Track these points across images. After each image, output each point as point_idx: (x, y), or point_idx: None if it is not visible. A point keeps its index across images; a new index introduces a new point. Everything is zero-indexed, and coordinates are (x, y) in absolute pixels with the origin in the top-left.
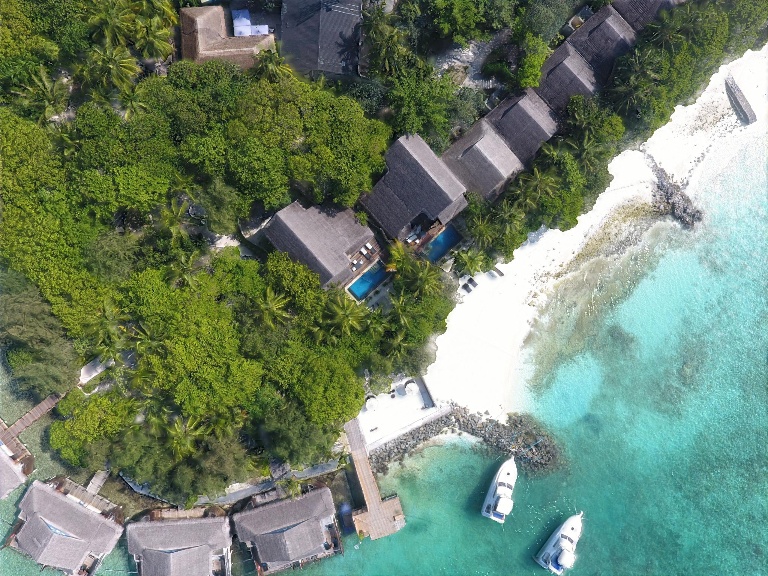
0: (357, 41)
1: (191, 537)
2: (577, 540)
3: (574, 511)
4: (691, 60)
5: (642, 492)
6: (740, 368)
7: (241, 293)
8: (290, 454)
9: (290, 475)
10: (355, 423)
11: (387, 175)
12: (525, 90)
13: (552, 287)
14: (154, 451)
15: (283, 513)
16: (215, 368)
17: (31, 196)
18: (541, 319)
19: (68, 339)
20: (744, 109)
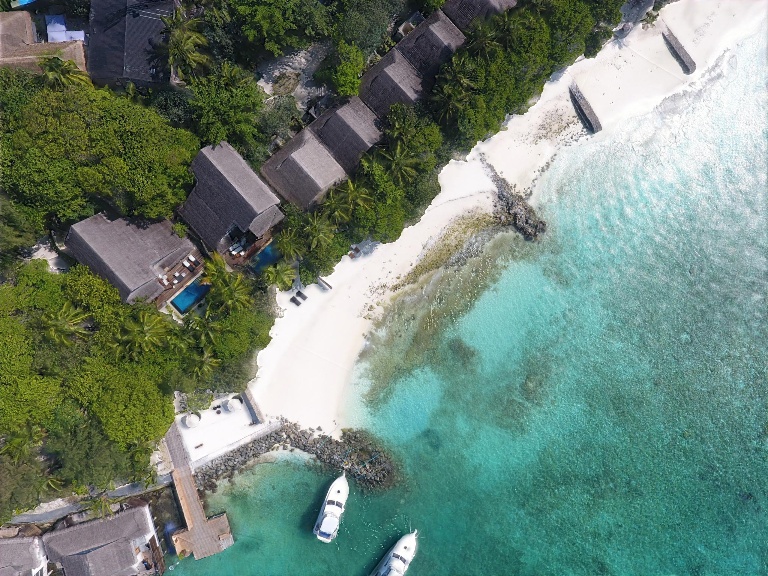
0: (169, 48)
1: None
2: (410, 559)
3: (408, 529)
4: (508, 68)
5: (483, 509)
6: (586, 382)
7: (38, 308)
8: (76, 475)
9: (109, 493)
10: (178, 440)
11: (197, 186)
12: (349, 98)
13: (389, 300)
14: None
15: (93, 533)
16: (5, 386)
17: None
18: (378, 332)
19: None
20: (588, 117)
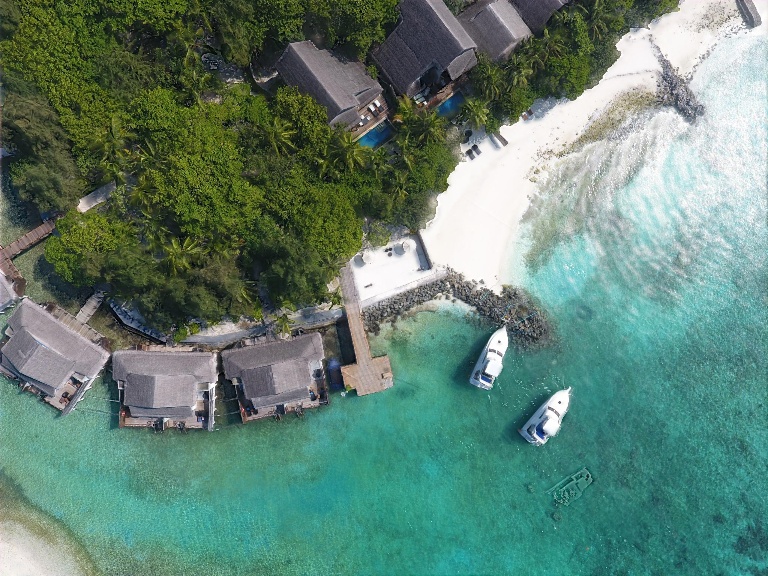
0: None
1: (177, 367)
2: (563, 415)
3: (562, 386)
4: None
5: (631, 377)
6: (734, 263)
7: (249, 121)
8: (285, 272)
9: None
10: (350, 277)
11: (401, 25)
12: None
13: (554, 165)
14: (149, 261)
15: (272, 352)
16: (217, 187)
17: (49, 11)
18: (541, 196)
19: (72, 155)
20: (750, 11)
